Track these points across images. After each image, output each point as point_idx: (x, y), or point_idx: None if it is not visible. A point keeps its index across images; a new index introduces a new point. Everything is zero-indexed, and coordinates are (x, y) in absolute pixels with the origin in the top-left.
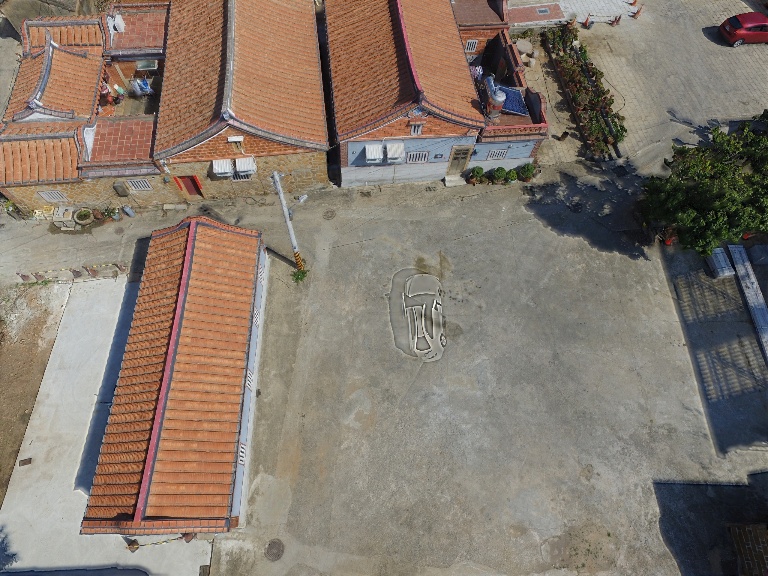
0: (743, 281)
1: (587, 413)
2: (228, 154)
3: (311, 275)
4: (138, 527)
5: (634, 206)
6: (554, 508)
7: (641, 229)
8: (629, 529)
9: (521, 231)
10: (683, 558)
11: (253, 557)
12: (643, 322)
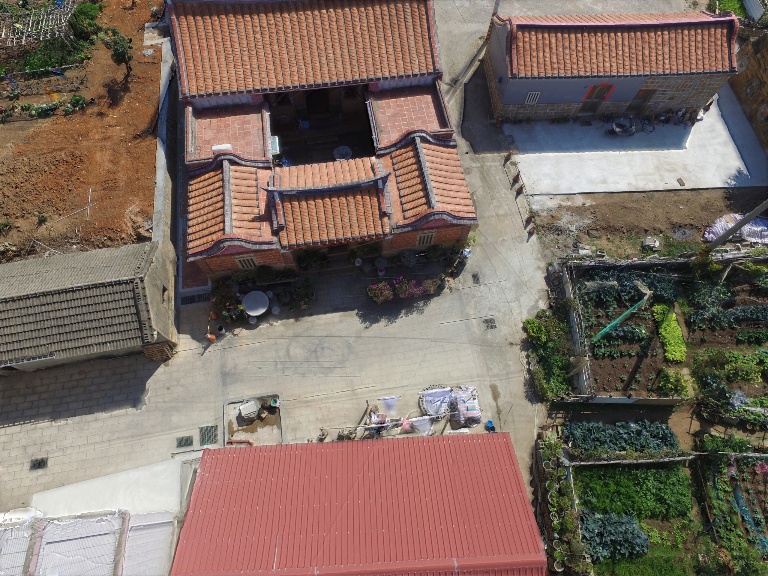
0: None
1: None
2: None
3: None
4: None
5: None
6: None
7: None
8: None
9: None
10: None
11: None
12: None
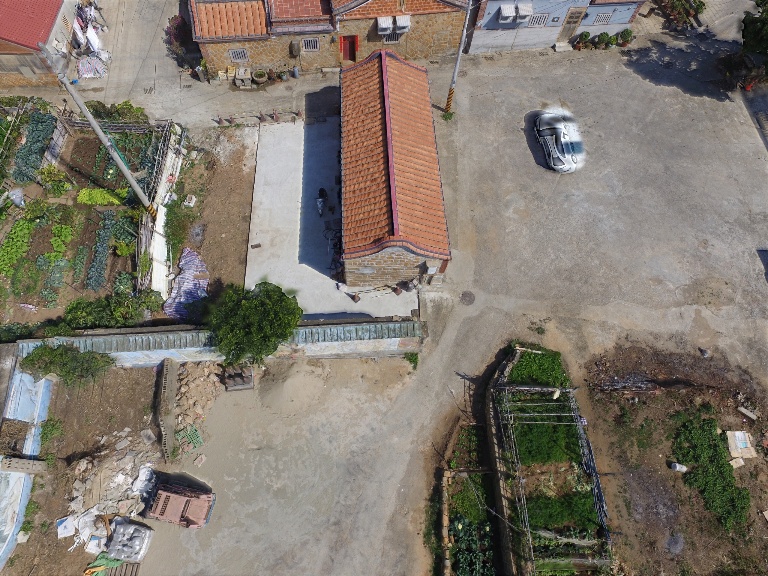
0: None
1: (698, 206)
2: (391, 12)
3: (457, 116)
4: (399, 239)
5: (717, 62)
6: (681, 267)
7: (725, 79)
8: (742, 280)
9: (624, 83)
10: None
11: (451, 303)
12: (734, 144)
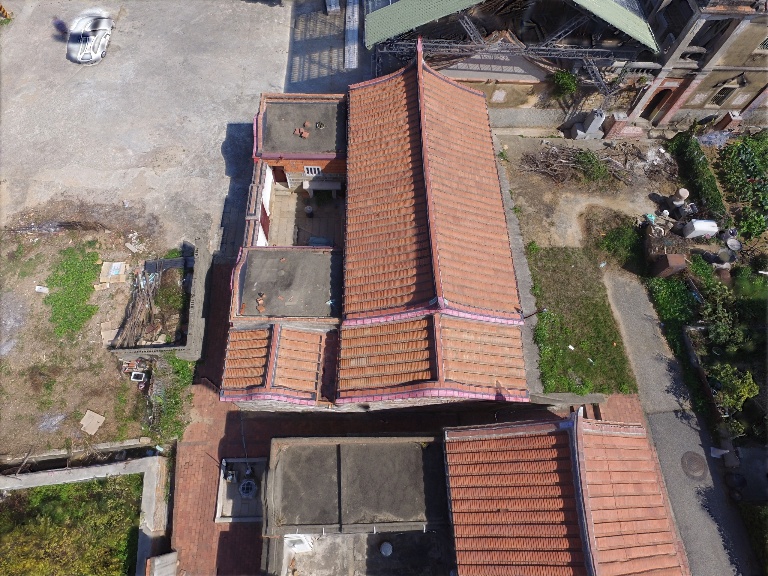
0: (347, 15)
1: (196, 90)
2: None
3: (14, 21)
4: None
5: None
6: (150, 138)
7: None
8: (199, 147)
9: None
10: (231, 160)
11: None
12: (261, 41)
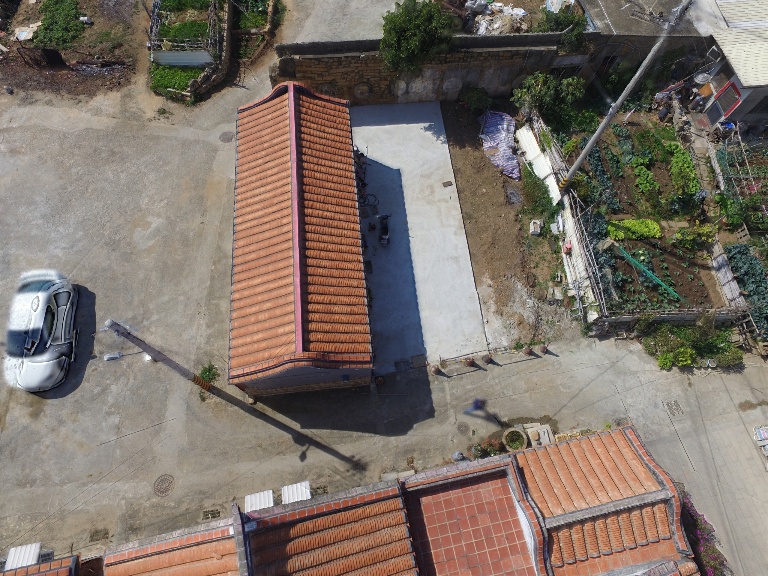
0: None
1: None
2: None
3: None
4: (289, 82)
5: None
6: None
7: None
8: None
9: None
10: None
11: None
12: None
